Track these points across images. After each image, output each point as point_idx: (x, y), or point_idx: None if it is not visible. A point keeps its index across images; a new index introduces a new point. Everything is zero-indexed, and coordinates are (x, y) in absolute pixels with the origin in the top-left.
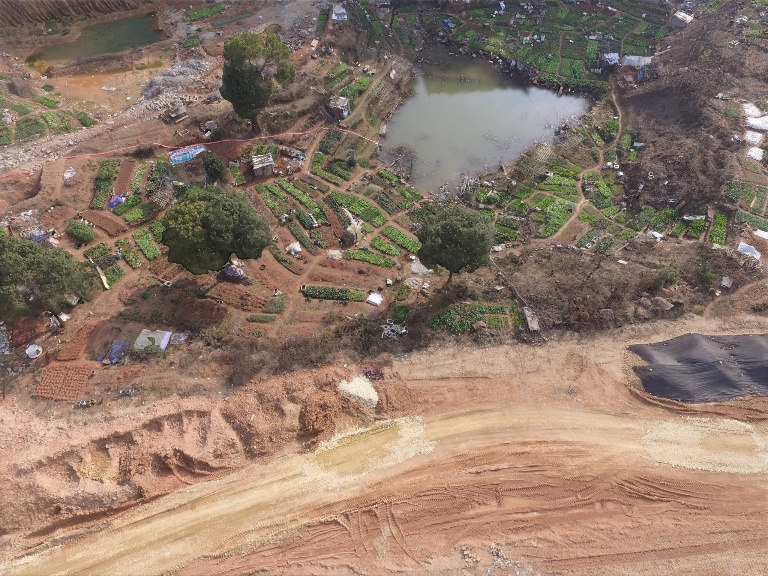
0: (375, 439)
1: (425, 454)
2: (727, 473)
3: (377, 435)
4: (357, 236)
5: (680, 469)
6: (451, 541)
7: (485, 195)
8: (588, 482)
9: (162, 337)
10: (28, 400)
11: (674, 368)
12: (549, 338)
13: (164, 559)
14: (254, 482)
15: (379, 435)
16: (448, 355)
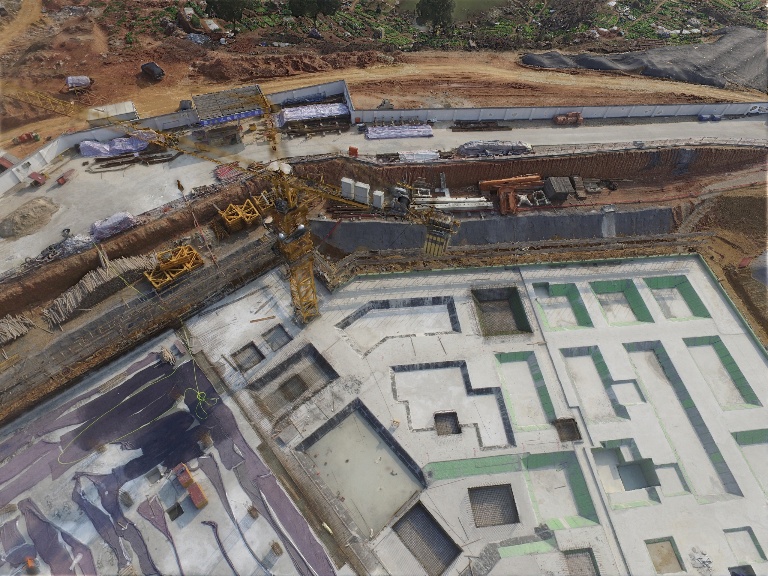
0: (393, 68)
1: (416, 73)
2: (555, 84)
3: (394, 67)
4: (382, 34)
5: (533, 82)
6: (426, 90)
7: (458, 31)
8: (490, 82)
9: (285, 44)
10: (226, 52)
11: (538, 55)
12: (480, 50)
13: (301, 87)
14: (338, 73)
15: (395, 67)
16: (429, 52)
